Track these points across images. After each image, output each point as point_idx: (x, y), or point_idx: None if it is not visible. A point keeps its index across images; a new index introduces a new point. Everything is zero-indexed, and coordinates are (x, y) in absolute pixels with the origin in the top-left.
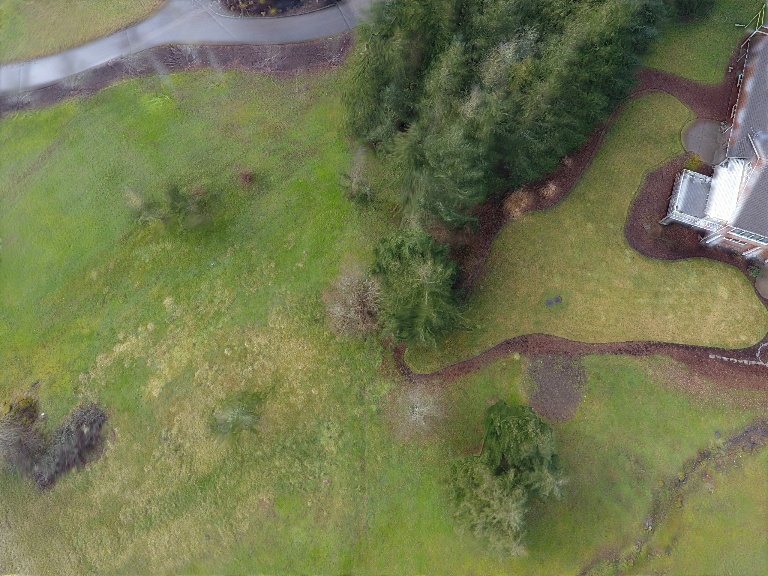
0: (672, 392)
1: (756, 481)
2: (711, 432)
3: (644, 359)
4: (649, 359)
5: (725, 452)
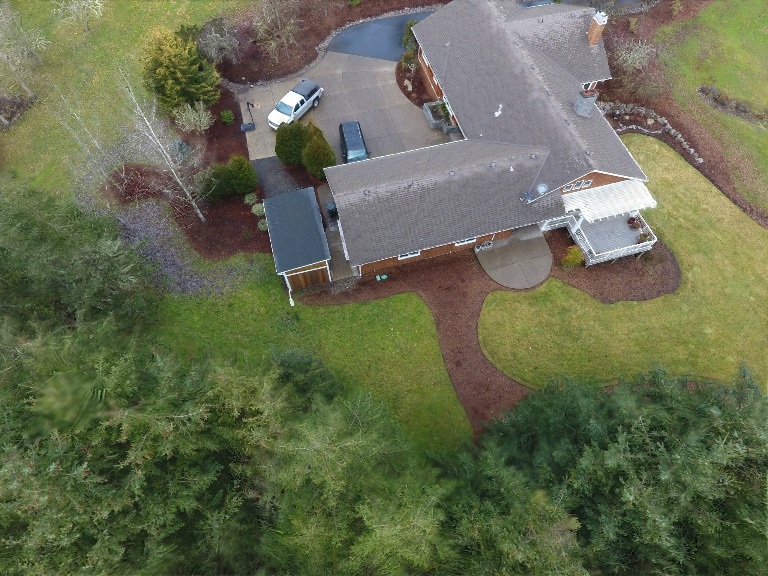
0: (765, 174)
1: (764, 96)
2: (764, 135)
3: (763, 208)
4: (759, 204)
5: (762, 122)
